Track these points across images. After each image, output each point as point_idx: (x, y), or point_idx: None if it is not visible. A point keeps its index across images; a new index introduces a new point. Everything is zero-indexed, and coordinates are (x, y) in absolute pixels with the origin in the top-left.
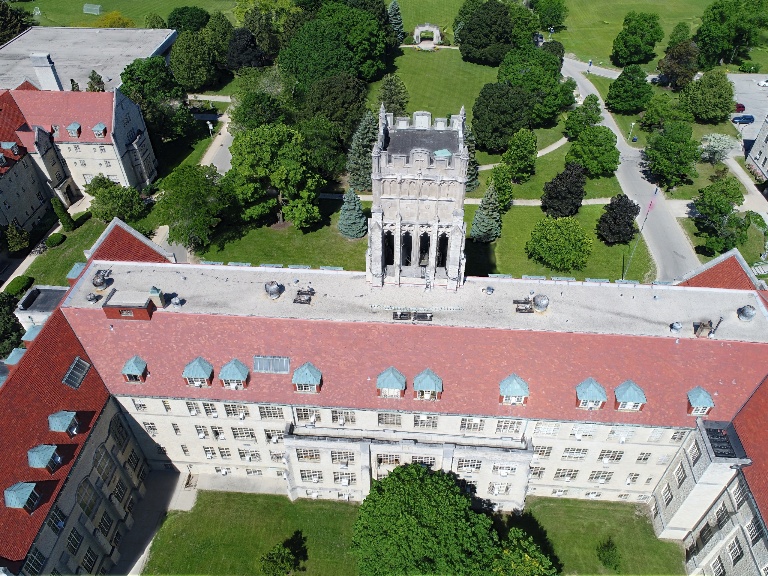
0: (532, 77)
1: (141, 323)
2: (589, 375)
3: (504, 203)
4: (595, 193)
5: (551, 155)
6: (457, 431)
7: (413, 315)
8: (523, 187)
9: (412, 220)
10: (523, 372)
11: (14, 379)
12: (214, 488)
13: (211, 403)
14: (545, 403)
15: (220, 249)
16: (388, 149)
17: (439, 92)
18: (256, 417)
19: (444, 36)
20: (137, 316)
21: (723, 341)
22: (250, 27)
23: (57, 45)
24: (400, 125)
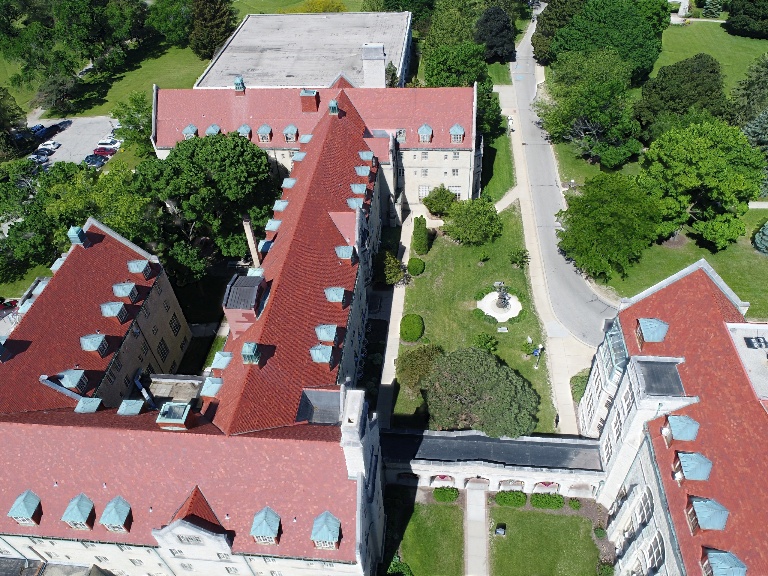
0: None
1: None
2: None
3: None
4: None
5: None
6: None
7: None
8: None
9: None
10: None
11: None
12: None
13: None
14: None
15: (623, 275)
16: None
17: None
18: None
19: (691, 7)
20: None
21: None
22: (492, 5)
23: (290, 34)
24: None
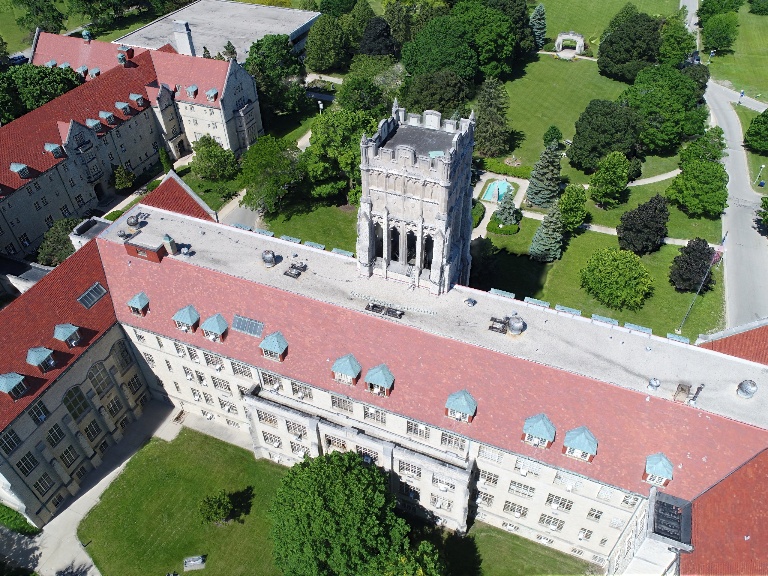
0: (652, 99)
1: (152, 264)
2: (542, 410)
3: (574, 225)
4: (688, 234)
5: (655, 185)
6: (404, 433)
7: (386, 309)
8: (608, 213)
9: (399, 216)
10: (475, 390)
11: (36, 288)
12: (196, 428)
13: (194, 349)
14: (490, 427)
15: (286, 219)
16: (388, 143)
17: (559, 103)
18: (230, 371)
19: (588, 47)
20: (150, 257)
21: (702, 411)
22: (389, 17)
23: (217, 16)
24: (411, 121)
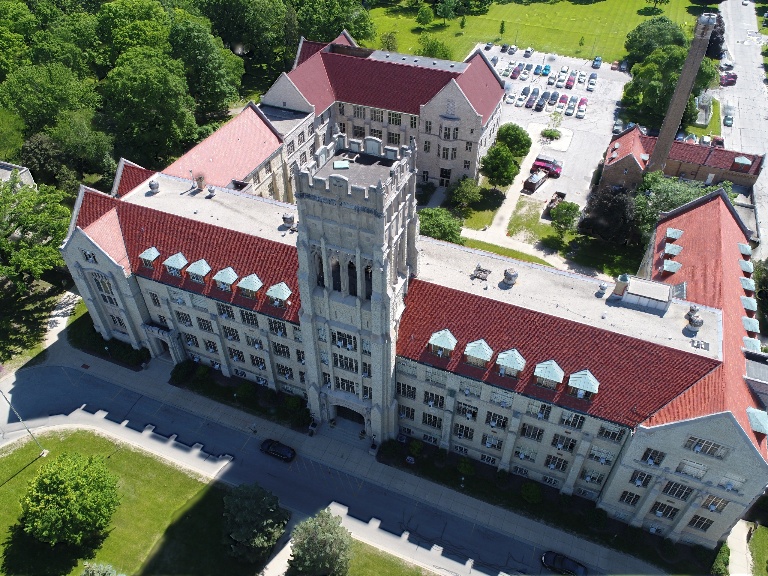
0: None
1: None
2: None
3: None
4: None
5: None
6: None
7: None
8: None
9: None
10: None
11: None
12: None
13: None
14: None
15: None
16: None
17: None
18: None
19: None
20: None
21: None
22: None
23: None
24: None
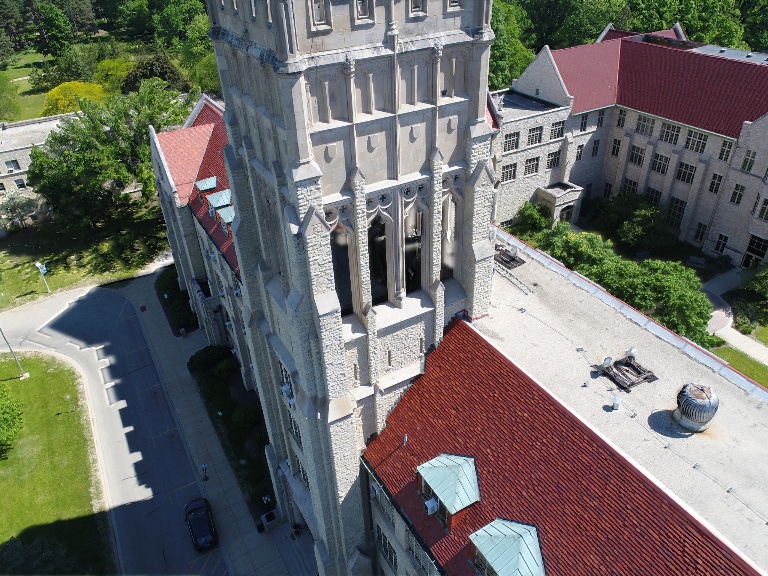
0: None
1: None
2: None
3: None
4: None
5: None
6: None
7: None
8: None
9: None
10: None
11: None
12: None
13: None
14: None
15: None
16: None
17: None
18: None
19: None
20: None
21: None
22: None
23: None
24: None
